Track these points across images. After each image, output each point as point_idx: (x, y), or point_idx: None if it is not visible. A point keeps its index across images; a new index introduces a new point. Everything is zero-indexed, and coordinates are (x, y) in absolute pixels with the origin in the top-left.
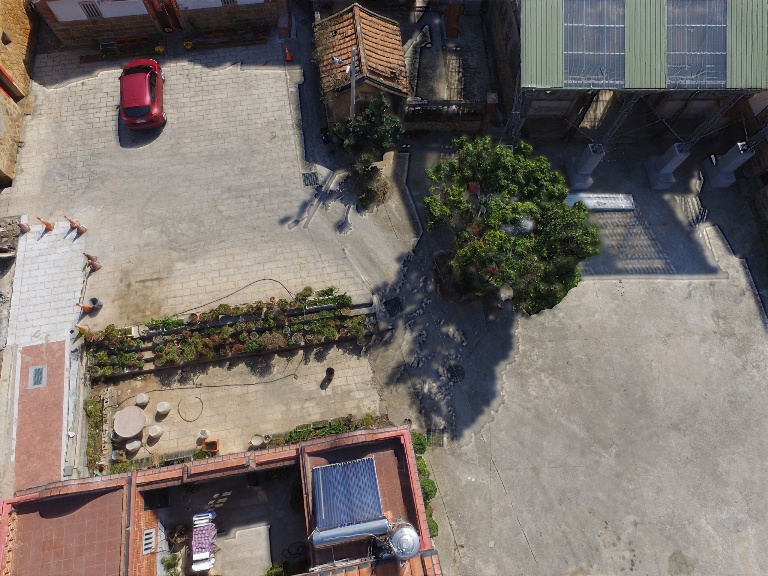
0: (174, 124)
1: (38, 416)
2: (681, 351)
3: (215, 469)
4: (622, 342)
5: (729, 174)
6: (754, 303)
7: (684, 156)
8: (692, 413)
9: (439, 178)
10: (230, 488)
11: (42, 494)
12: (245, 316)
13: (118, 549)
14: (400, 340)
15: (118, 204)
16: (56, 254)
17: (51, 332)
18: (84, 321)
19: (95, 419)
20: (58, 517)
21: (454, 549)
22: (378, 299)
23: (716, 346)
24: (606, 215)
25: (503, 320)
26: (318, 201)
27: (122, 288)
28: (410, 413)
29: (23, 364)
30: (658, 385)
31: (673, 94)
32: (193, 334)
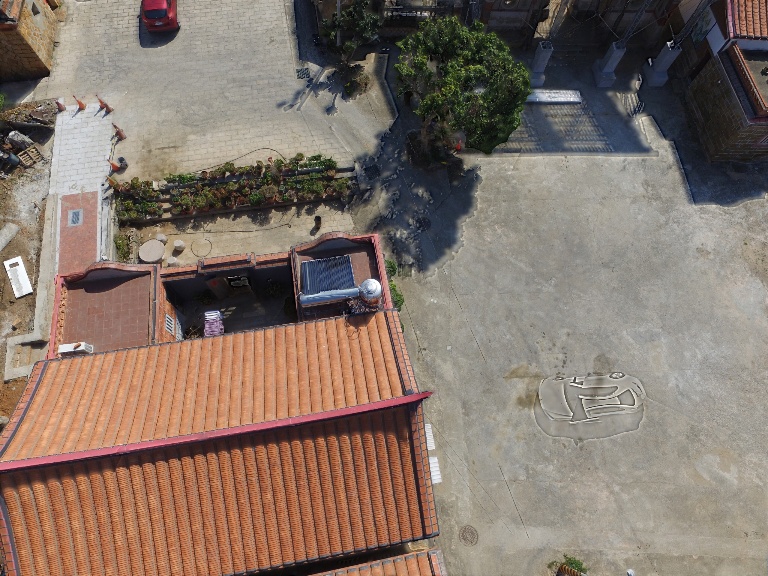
0: (187, 30)
1: (76, 246)
2: (614, 210)
3: (223, 262)
4: (565, 202)
5: (663, 73)
6: (679, 174)
7: (621, 53)
8: (620, 255)
9: (407, 48)
10: (234, 304)
11: (88, 268)
12: (247, 175)
13: (147, 314)
14: (377, 198)
15: (140, 90)
16: (88, 127)
17: (86, 185)
18: (113, 177)
19: (123, 251)
20: (99, 292)
21: (418, 351)
22: (359, 166)
23: (644, 206)
24: (556, 107)
25: (465, 185)
26: (309, 90)
27: (144, 153)
28: (384, 252)
29: (63, 208)
30: (593, 234)
31: (615, 5)
32: (204, 188)
